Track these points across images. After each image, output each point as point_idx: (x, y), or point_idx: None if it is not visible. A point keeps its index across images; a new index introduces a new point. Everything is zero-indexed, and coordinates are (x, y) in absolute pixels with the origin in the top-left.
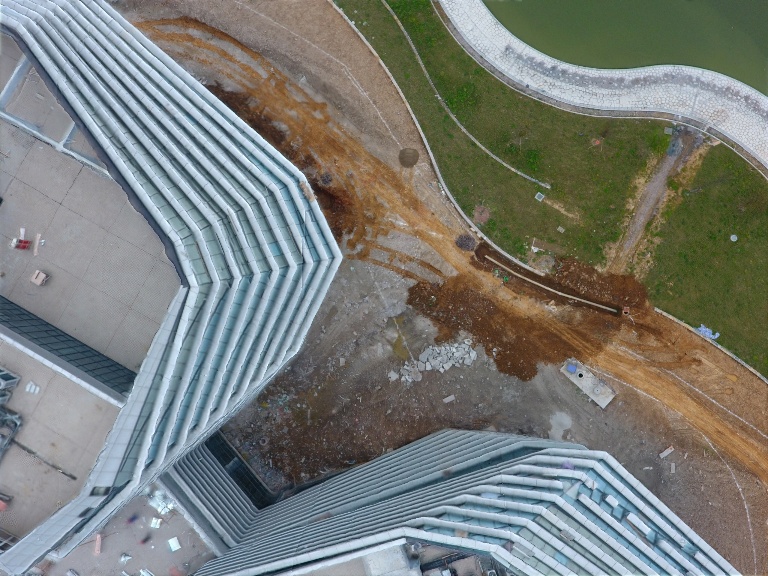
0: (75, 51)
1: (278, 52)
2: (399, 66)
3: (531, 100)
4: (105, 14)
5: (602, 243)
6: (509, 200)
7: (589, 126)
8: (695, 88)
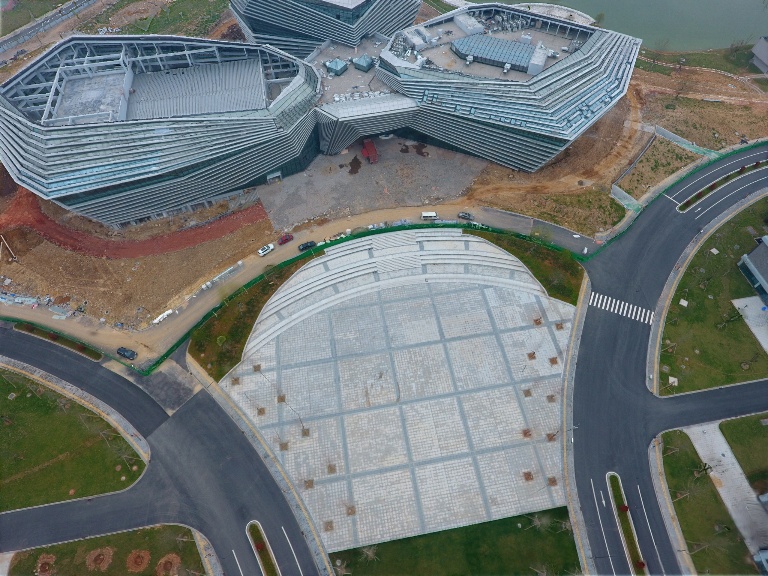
0: None
1: None
2: None
3: None
4: None
5: None
6: None
7: None
8: (538, 7)
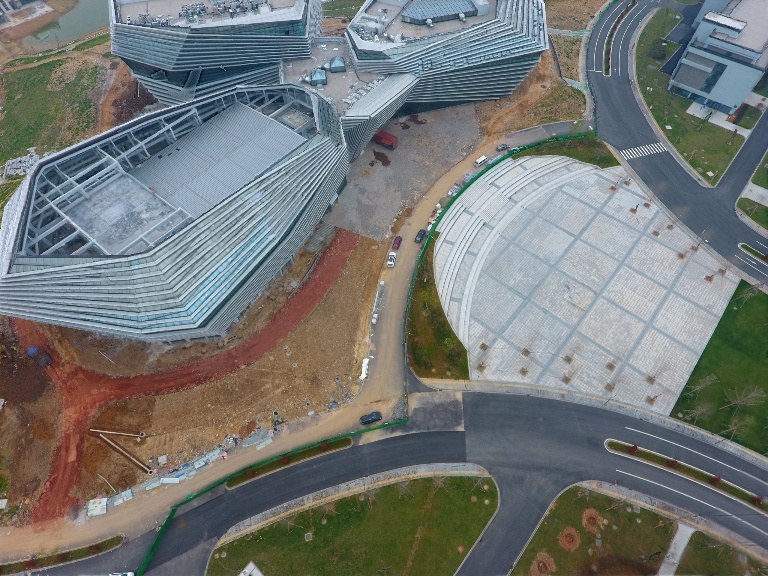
0: None
1: None
2: None
3: (328, 2)
4: None
5: None
6: None
7: None
8: None
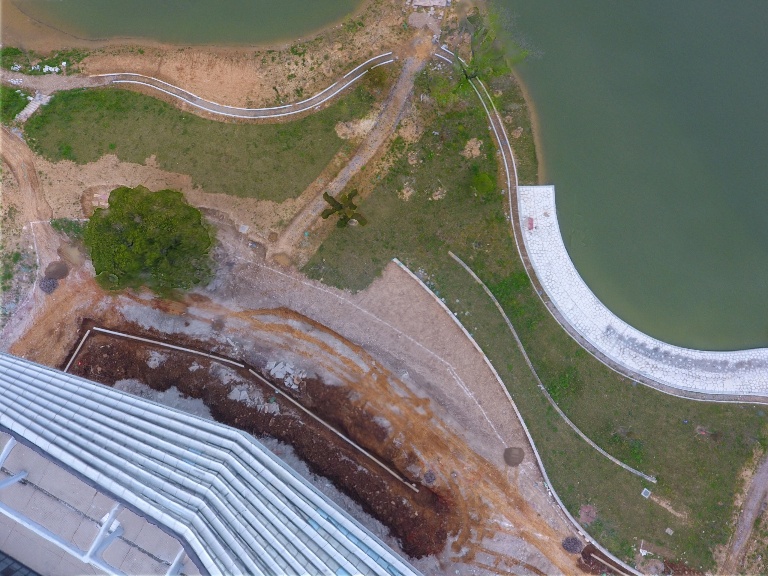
0: (235, 531)
1: (381, 349)
2: (502, 357)
3: None
4: (256, 463)
5: (712, 546)
6: (615, 498)
7: (693, 411)
8: None
